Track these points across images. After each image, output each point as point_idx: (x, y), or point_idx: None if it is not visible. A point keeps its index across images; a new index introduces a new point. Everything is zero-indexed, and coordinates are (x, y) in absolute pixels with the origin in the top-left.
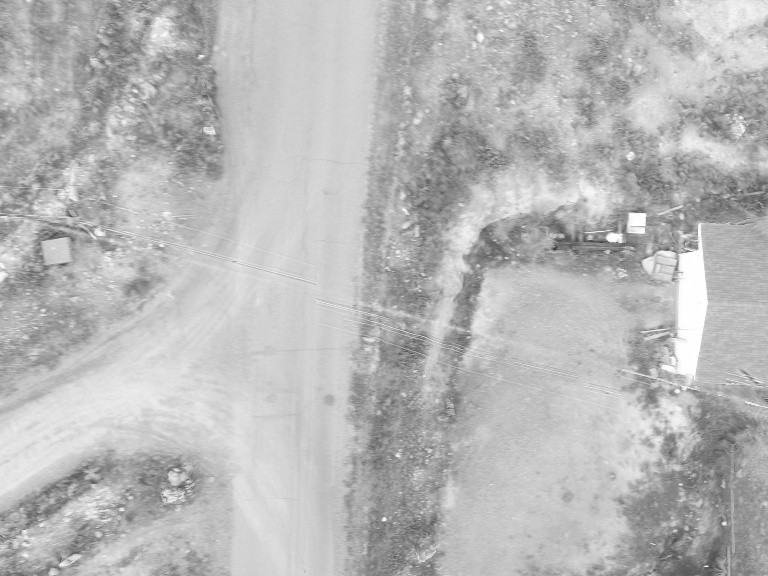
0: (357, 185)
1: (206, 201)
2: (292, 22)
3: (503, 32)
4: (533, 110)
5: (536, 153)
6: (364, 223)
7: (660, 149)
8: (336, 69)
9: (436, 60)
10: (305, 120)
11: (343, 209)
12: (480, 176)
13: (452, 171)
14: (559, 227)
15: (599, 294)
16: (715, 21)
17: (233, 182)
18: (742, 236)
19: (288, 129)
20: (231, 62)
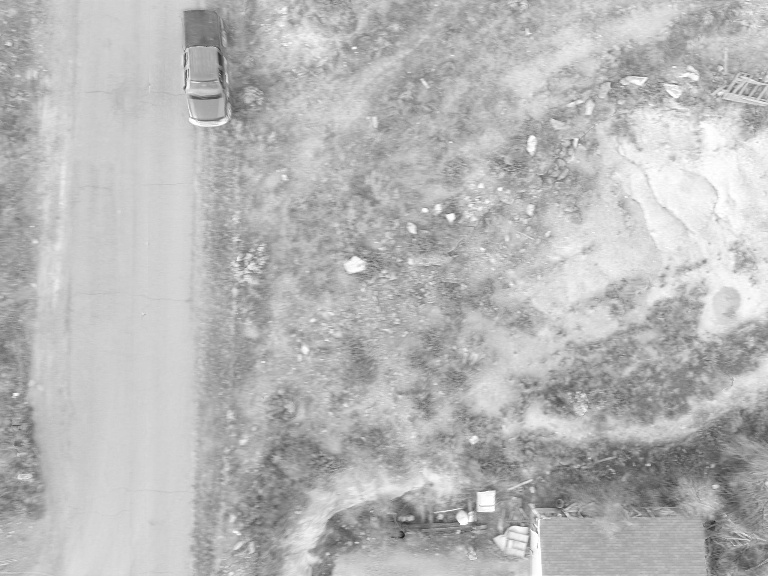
0: (183, 513)
1: (28, 542)
2: (109, 351)
3: (329, 341)
4: (368, 409)
5: (373, 452)
6: (192, 552)
7: (504, 430)
8: (156, 397)
9: (260, 378)
10: (127, 451)
11: (170, 538)
12: (316, 481)
13: (285, 483)
14: (408, 509)
15: (452, 573)
16: (554, 296)
17: (56, 518)
18: (581, 532)
19: (110, 461)
20: (48, 396)
